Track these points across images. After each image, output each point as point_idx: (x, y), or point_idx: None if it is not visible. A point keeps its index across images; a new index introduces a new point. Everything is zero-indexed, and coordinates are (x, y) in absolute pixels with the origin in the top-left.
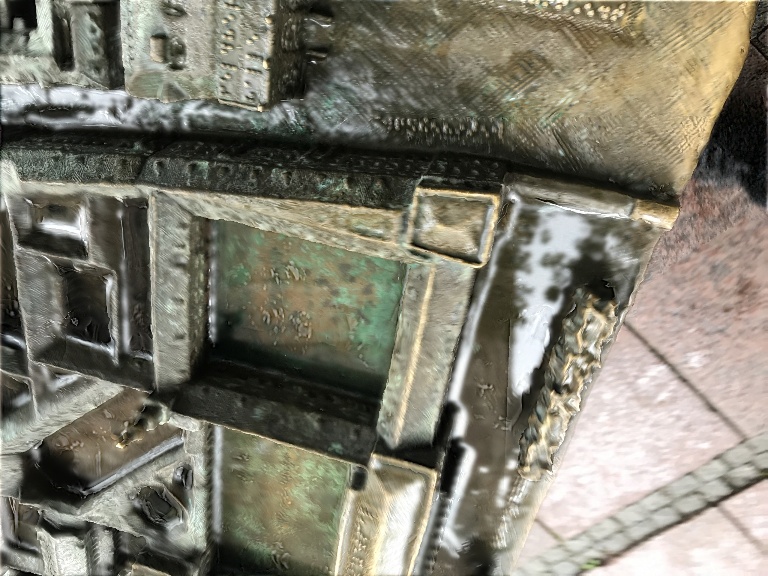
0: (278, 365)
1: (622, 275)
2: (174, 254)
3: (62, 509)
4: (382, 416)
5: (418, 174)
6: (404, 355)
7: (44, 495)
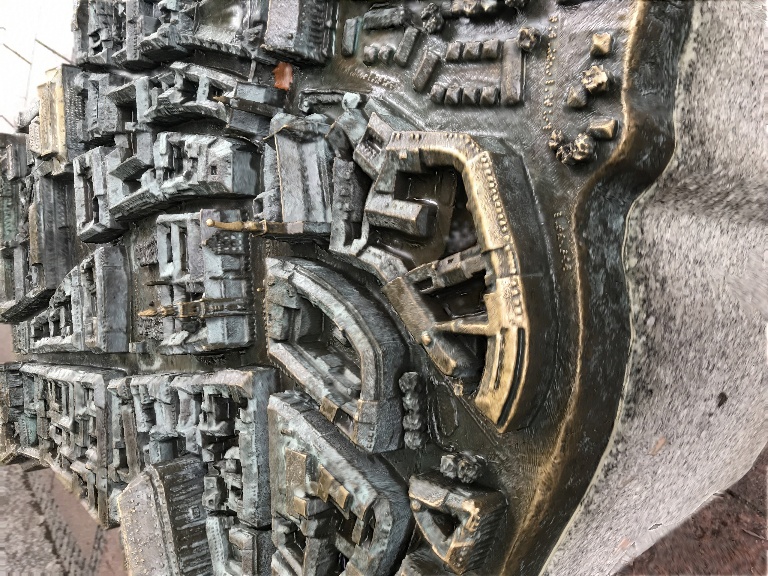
0: None
1: None
2: None
3: None
4: (3, 263)
5: None
6: (1, 282)
7: None
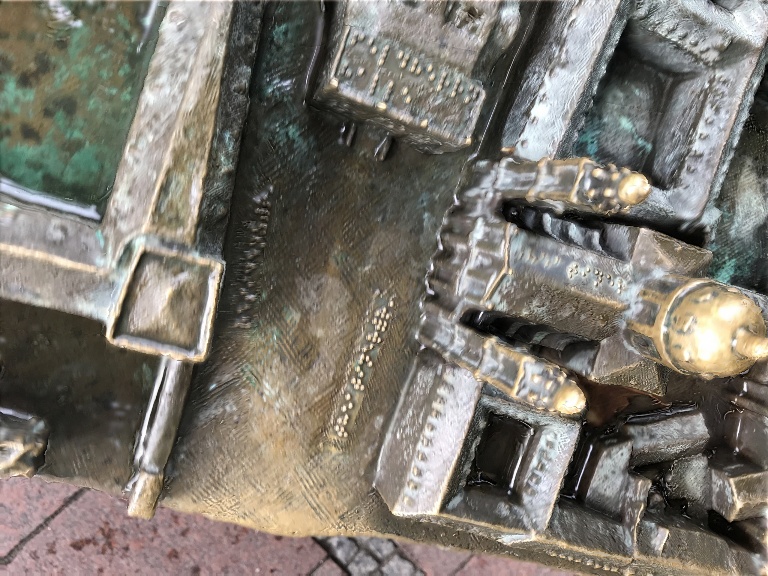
0: None
1: (55, 459)
2: None
3: None
4: None
5: None
6: None
7: None
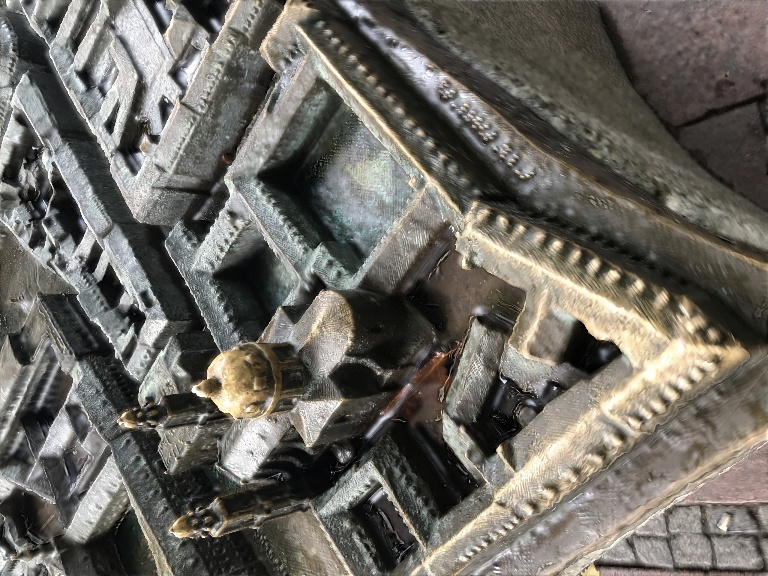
0: (137, 575)
1: None
2: (108, 486)
3: (12, 530)
4: None
5: (217, 573)
6: None
7: (12, 513)
